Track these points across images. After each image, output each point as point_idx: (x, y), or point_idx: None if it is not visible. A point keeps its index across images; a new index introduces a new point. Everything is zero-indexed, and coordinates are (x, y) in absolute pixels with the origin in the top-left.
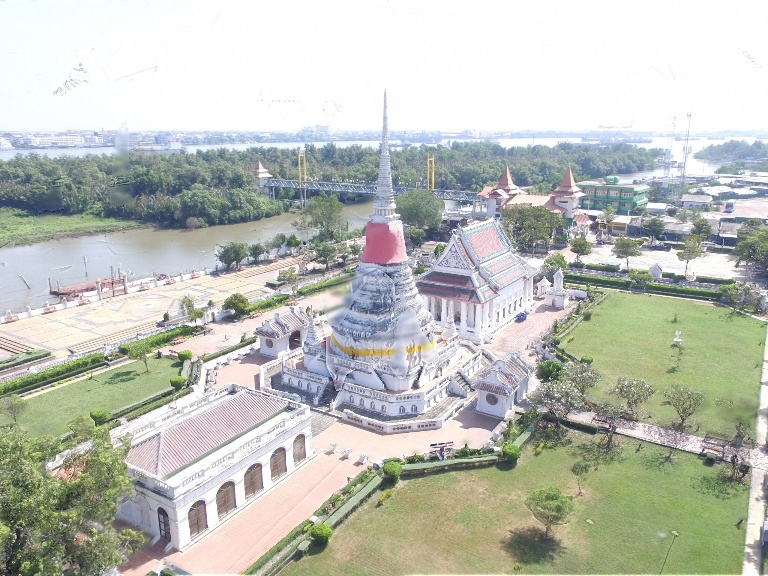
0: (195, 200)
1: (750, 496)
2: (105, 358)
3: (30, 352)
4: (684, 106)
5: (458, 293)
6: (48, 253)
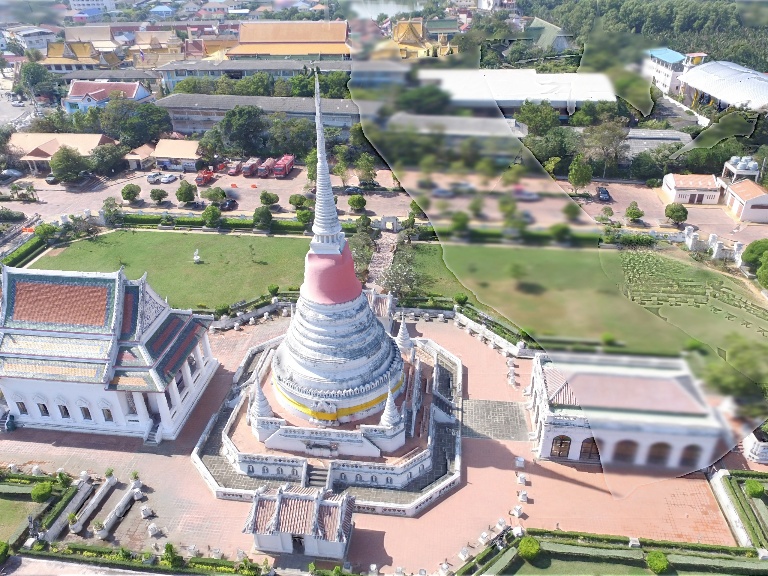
0: None
1: (429, 243)
2: None
3: None
4: (225, 47)
5: (193, 334)
6: None
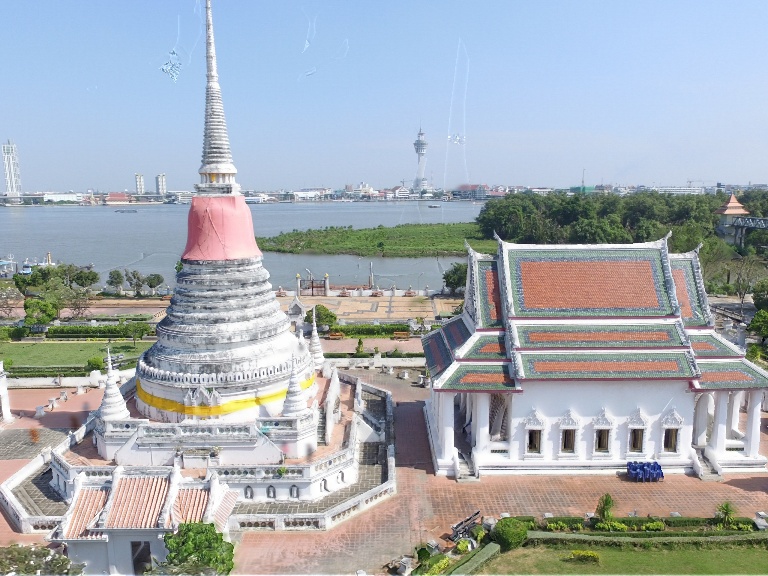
0: (586, 230)
1: None
2: (149, 332)
3: (142, 314)
4: None
5: (439, 361)
6: (415, 265)
